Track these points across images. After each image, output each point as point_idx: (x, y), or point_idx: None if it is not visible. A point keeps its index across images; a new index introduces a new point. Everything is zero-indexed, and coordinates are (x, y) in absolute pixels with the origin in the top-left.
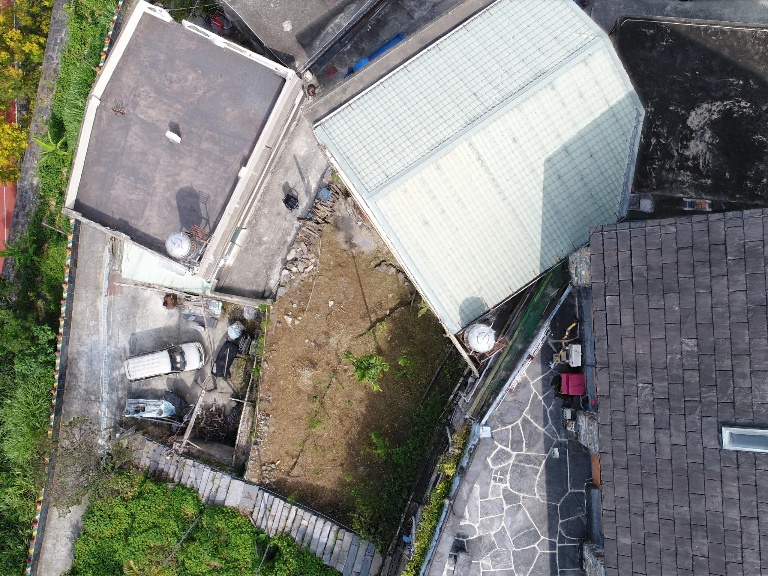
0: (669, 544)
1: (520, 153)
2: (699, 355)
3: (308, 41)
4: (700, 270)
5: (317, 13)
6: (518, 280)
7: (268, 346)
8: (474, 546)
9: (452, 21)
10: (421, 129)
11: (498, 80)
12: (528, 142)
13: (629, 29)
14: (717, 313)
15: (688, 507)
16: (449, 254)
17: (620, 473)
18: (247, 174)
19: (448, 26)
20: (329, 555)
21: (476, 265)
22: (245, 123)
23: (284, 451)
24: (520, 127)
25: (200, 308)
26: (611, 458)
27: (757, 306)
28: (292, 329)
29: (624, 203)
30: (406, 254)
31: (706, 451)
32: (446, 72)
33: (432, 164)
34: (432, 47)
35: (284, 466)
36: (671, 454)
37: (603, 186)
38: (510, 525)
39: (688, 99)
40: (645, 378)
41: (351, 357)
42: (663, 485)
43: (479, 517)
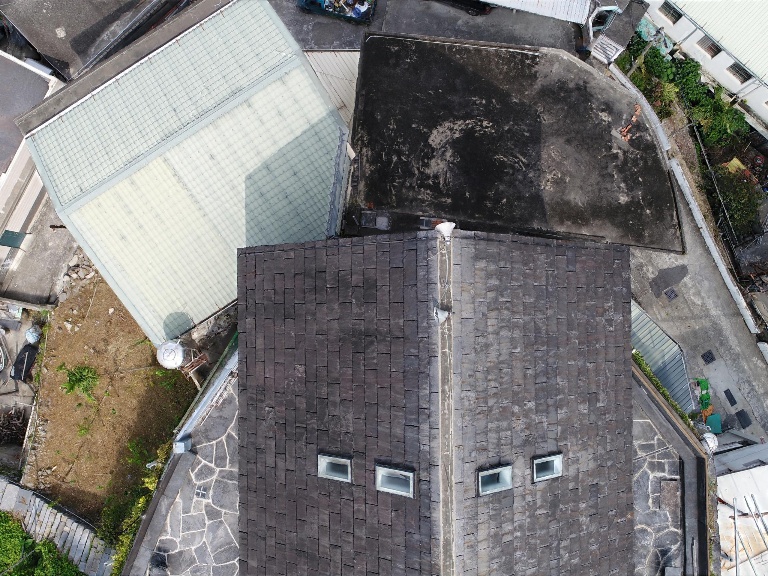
0: (282, 569)
1: (219, 170)
2: (306, 382)
3: (83, 48)
4: (308, 297)
5: (92, 20)
6: (224, 296)
7: (48, 352)
8: (175, 560)
9: (168, 35)
10: (120, 143)
11: (198, 96)
12: (226, 159)
13: (374, 45)
14: (319, 340)
15: (296, 533)
16: (149, 269)
17: (251, 496)
18: (9, 180)
19: (164, 40)
20: (85, 562)
21: (179, 280)
22: (13, 129)
23: (61, 457)
24: (217, 144)
25: (0, 311)
26: (246, 480)
27: (345, 335)
28: (72, 335)
29: (332, 222)
30: (104, 268)
31: (308, 478)
32: (152, 86)
33: (126, 179)
34: (145, 61)
35: (60, 472)
36: (285, 479)
37: (309, 204)
38: (211, 540)
39: (430, 117)
40: (270, 402)
41: (63, 369)
42: (279, 510)
43: (181, 532)
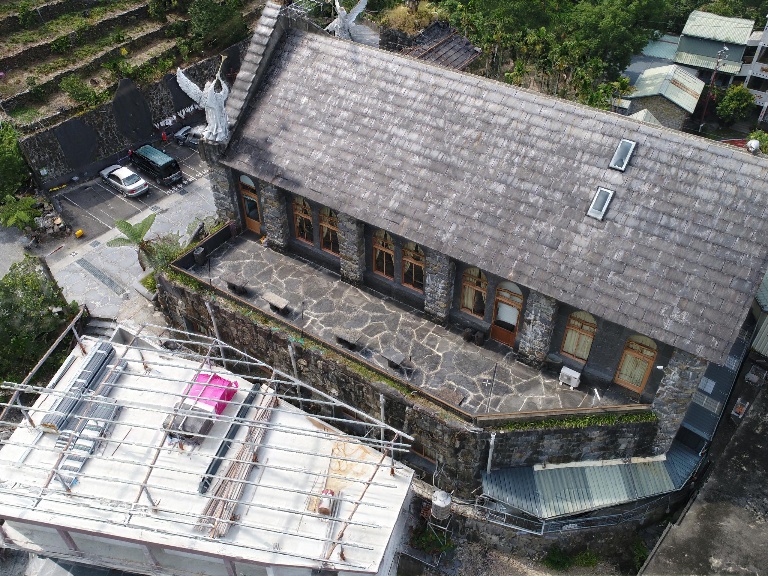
0: None
1: None
2: None
3: None
4: None
5: None
6: None
7: None
8: None
9: None
10: None
11: None
12: None
13: None
14: None
15: None
16: None
17: None
18: None
19: None
20: None
21: None
22: None
23: None
24: None
25: None
26: None
27: None
28: None
29: None
30: None
31: None
32: None
33: None
34: None
35: None
36: None
37: None
38: None
39: None
40: None
41: None
42: None
43: None
